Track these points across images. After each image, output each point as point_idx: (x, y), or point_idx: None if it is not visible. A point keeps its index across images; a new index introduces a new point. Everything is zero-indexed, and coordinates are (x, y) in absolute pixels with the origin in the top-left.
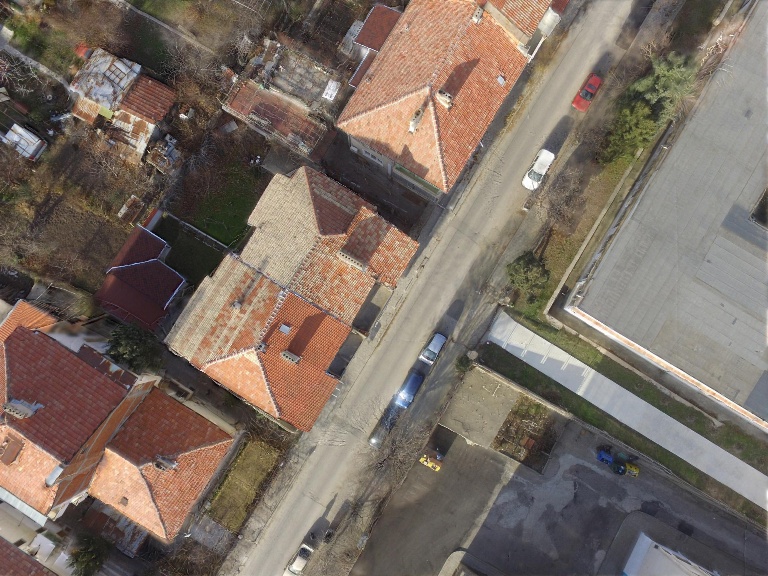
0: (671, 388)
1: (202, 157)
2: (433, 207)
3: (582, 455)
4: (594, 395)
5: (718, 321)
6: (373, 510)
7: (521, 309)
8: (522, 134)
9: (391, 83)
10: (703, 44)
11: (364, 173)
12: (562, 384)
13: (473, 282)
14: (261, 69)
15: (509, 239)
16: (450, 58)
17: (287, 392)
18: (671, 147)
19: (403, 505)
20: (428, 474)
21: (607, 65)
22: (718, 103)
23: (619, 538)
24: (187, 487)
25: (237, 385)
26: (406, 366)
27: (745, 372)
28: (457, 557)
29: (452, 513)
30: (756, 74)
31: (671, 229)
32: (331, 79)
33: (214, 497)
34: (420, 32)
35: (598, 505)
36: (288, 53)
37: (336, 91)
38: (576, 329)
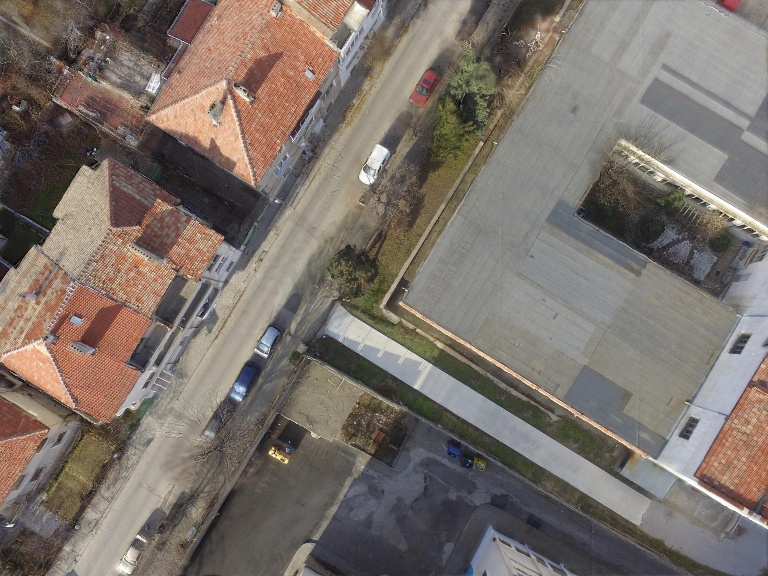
0: (509, 382)
1: (30, 149)
2: (265, 201)
3: (433, 449)
4: (431, 389)
5: (539, 316)
6: (208, 501)
7: (358, 303)
8: (361, 129)
9: (196, 76)
10: (521, 40)
11: (202, 166)
12: (398, 378)
13: (311, 276)
14: (90, 61)
15: (347, 233)
16: (248, 51)
17: (83, 383)
18: (498, 143)
19: (255, 497)
20: (280, 467)
21: (446, 60)
22: (546, 99)
23: (467, 531)
24: (3, 477)
25: (34, 376)
26: (243, 359)
27: (565, 367)
28: (307, 549)
29: (303, 505)
30: (584, 71)
31: (495, 224)
32: (154, 72)
33: (51, 488)
34: (226, 25)
35: (448, 498)
36: (116, 45)
37: (158, 84)
38: (416, 323)
